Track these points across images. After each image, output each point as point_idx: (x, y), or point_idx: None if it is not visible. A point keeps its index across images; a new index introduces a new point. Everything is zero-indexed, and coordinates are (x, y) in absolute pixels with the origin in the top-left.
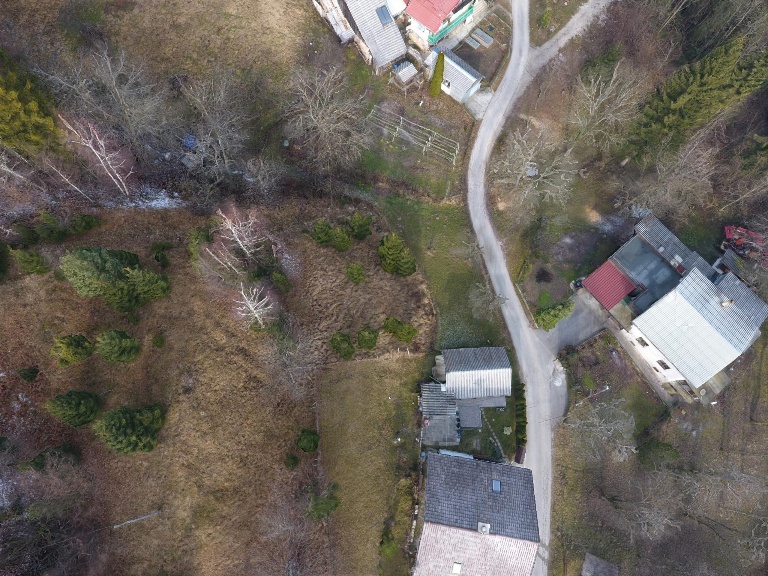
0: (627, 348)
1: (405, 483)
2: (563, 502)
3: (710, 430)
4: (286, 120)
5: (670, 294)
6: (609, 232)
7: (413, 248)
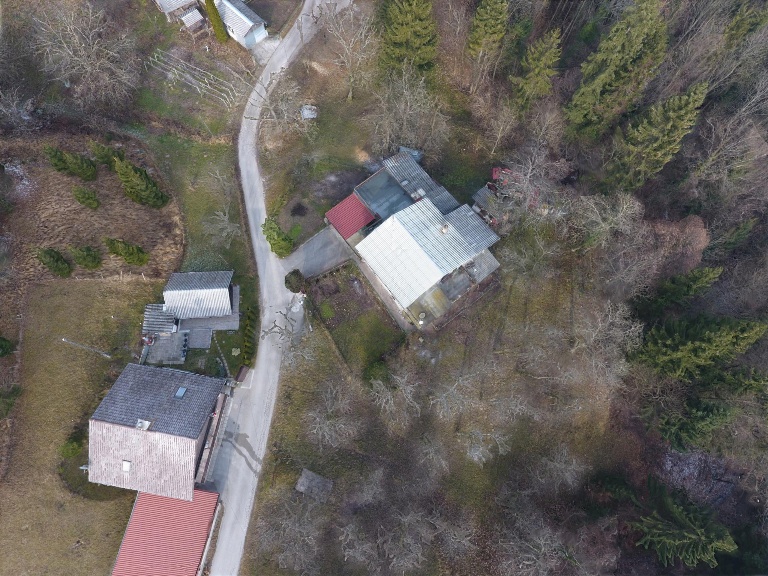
0: (370, 278)
1: None
2: (285, 420)
3: (450, 358)
4: None
5: (388, 220)
6: None
7: (176, 183)
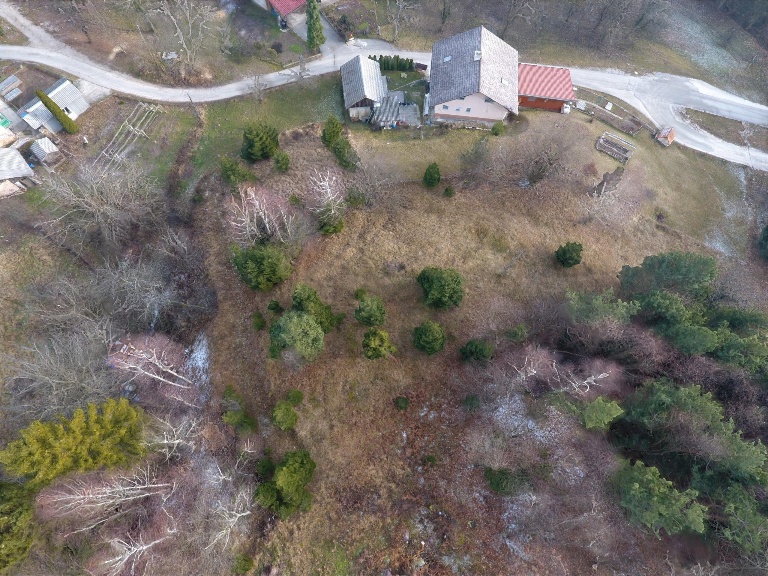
0: (335, 1)
1: None
2: None
3: None
4: (93, 265)
5: None
6: (235, 6)
7: None
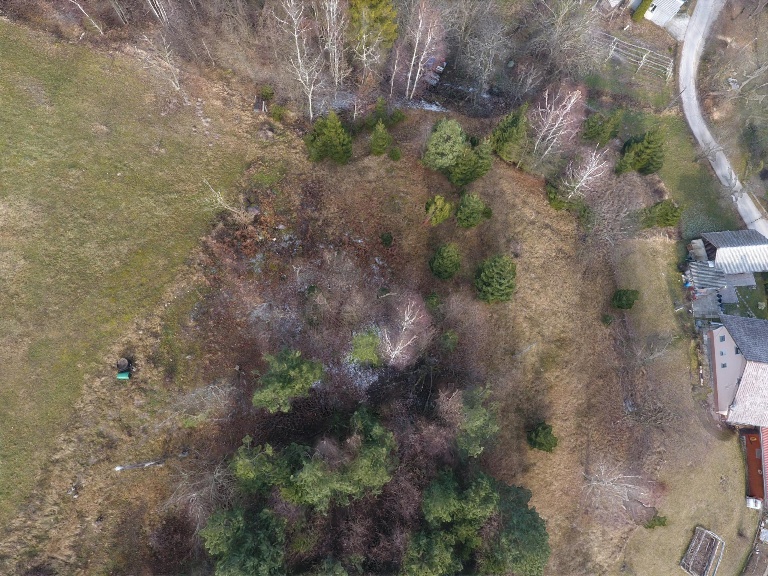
0: None
1: (692, 345)
2: None
3: None
4: None
5: None
6: None
7: None
